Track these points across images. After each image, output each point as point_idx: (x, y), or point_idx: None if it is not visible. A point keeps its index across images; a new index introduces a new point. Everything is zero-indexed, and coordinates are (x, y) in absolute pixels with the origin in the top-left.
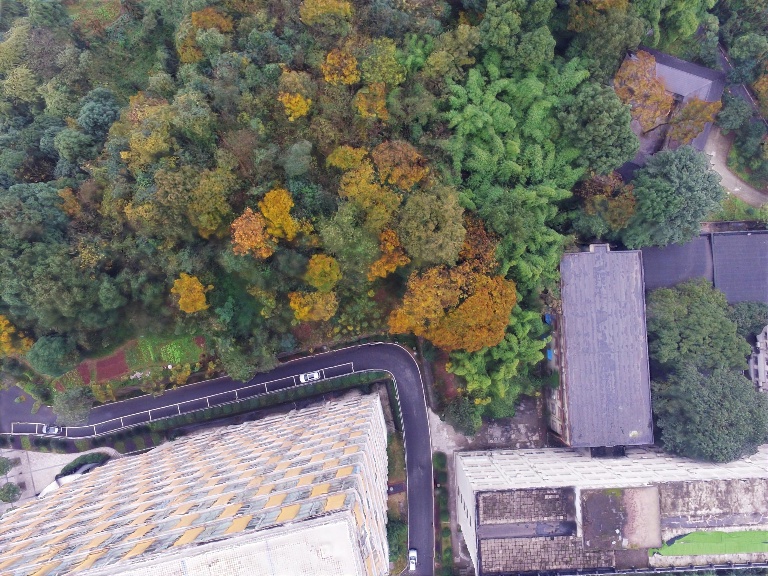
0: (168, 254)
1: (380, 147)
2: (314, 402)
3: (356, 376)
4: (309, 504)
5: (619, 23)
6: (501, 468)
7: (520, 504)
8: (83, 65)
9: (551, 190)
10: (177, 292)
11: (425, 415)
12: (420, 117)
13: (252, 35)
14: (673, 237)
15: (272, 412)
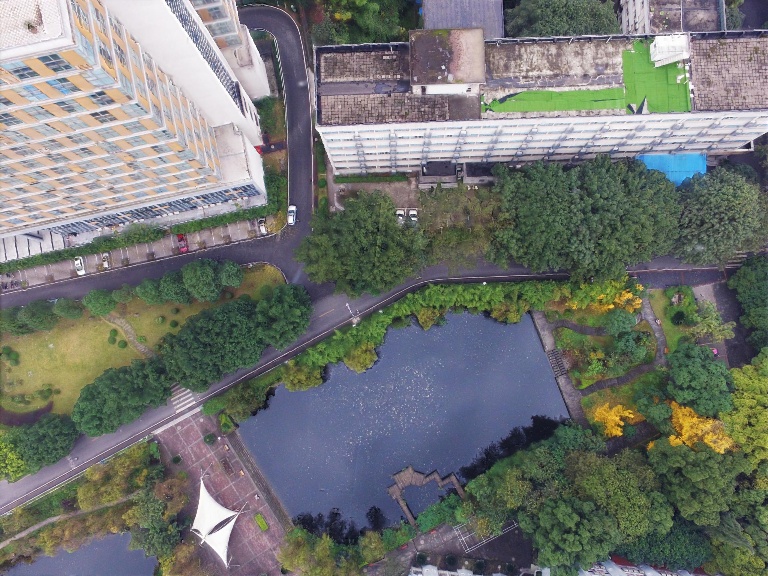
0: None
1: None
2: None
3: None
4: None
5: None
6: None
7: (359, 64)
8: None
9: None
10: None
11: (305, 75)
12: None
13: None
14: None
15: None
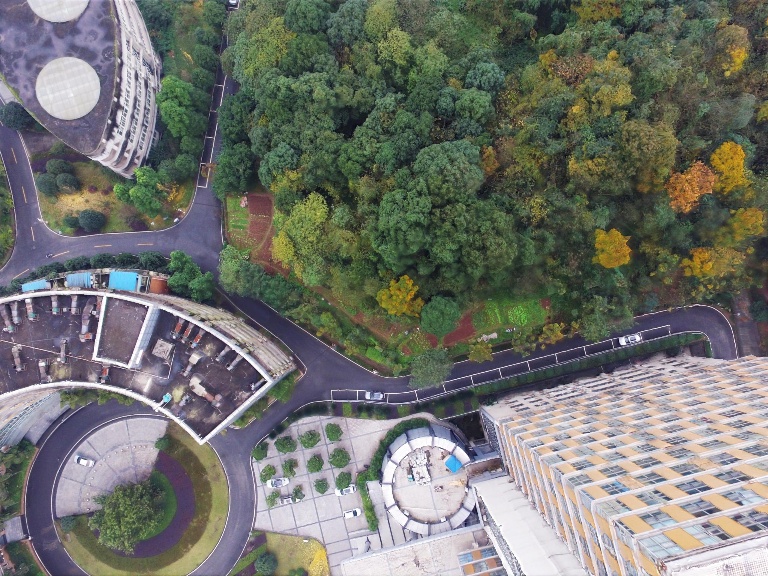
0: (583, 211)
1: None
2: (620, 366)
3: (676, 338)
4: None
5: None
6: None
7: None
8: (461, 27)
9: None
10: (601, 247)
11: None
12: None
13: None
14: None
15: (580, 376)
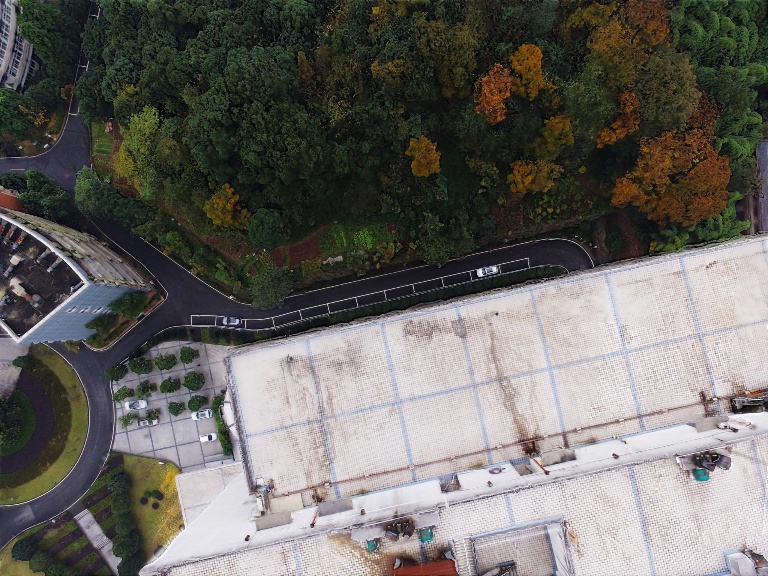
0: (398, 120)
1: (630, 2)
2: None
3: (533, 271)
4: None
5: None
6: None
7: None
8: None
9: (764, 68)
10: (412, 155)
11: None
12: None
13: None
14: None
15: None
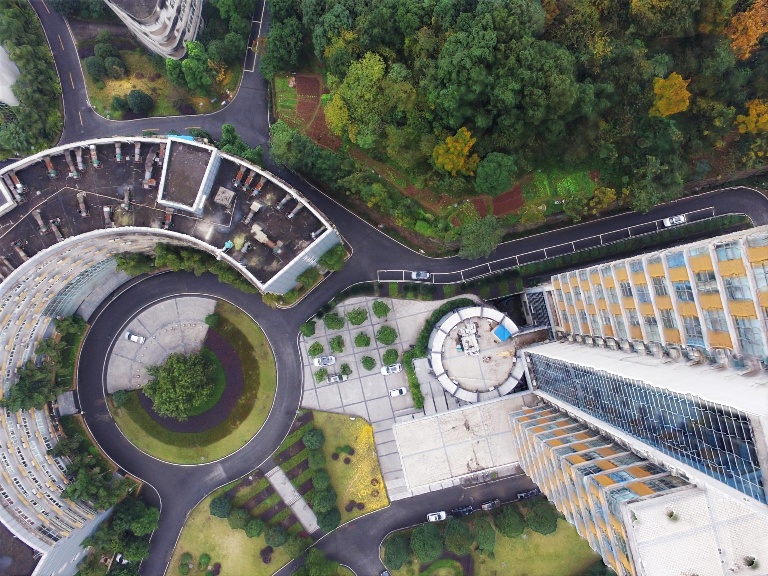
0: (642, 59)
1: None
2: None
3: (720, 219)
4: None
5: None
6: None
7: None
8: None
9: None
10: (661, 93)
11: None
12: None
13: None
14: None
15: None
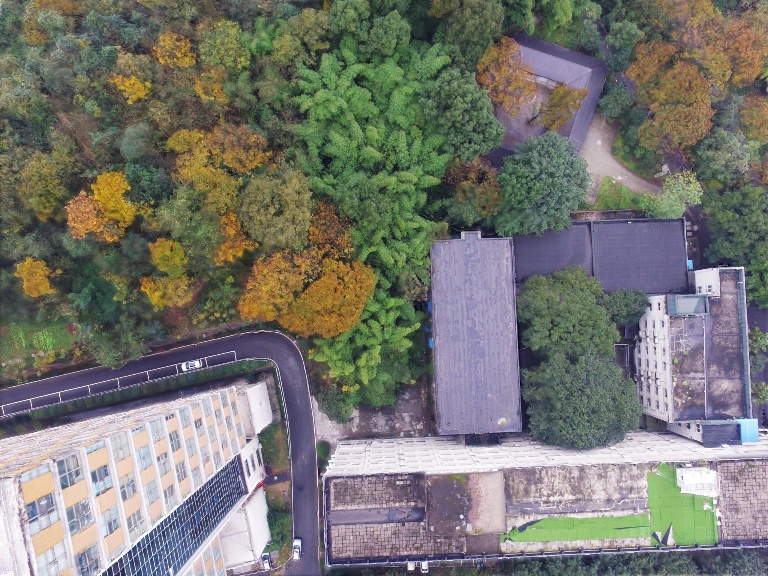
0: (15, 238)
1: (214, 130)
2: (201, 391)
3: (238, 364)
4: (0, 474)
5: (473, 8)
6: (369, 455)
7: (371, 490)
8: None
9: (411, 176)
10: (20, 276)
11: (309, 404)
12: (272, 101)
13: (89, 17)
14: (541, 224)
15: (158, 401)
